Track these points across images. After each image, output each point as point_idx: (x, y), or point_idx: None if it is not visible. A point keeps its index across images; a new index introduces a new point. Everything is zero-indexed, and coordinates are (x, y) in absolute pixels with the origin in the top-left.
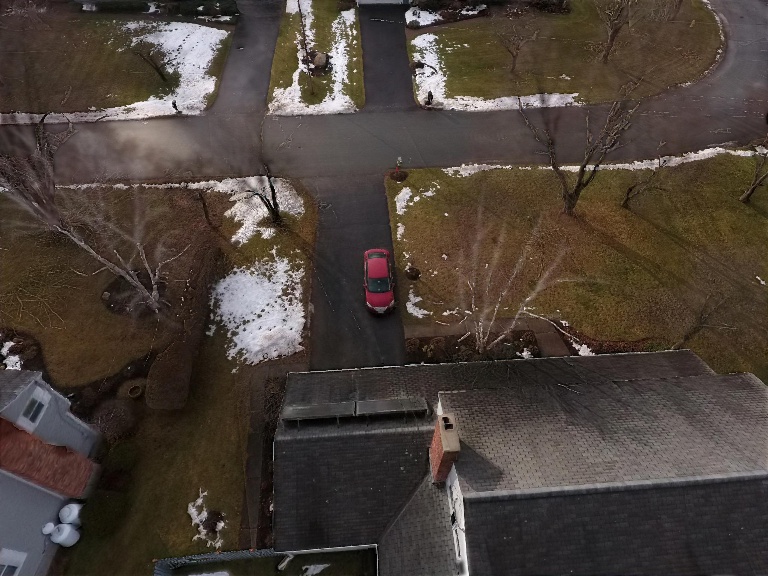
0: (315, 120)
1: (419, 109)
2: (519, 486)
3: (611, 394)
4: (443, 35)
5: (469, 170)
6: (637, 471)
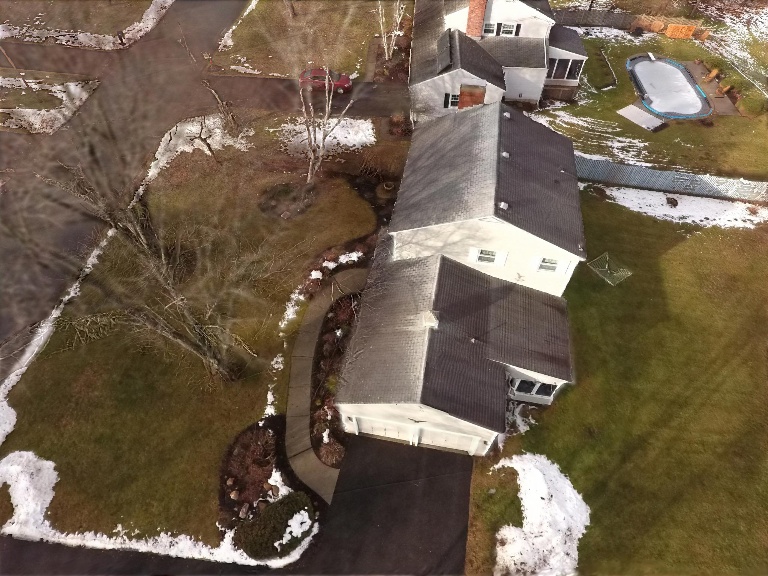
0: (93, 103)
1: (125, 51)
2: None
3: None
4: (7, 20)
5: (227, 41)
6: None
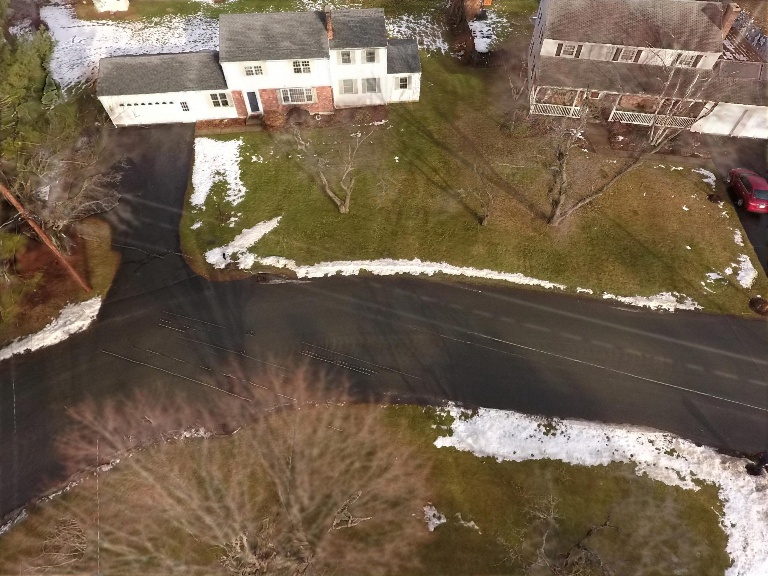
0: None
1: None
2: (696, 4)
3: (630, 38)
4: None
5: (664, 299)
6: (643, 3)
